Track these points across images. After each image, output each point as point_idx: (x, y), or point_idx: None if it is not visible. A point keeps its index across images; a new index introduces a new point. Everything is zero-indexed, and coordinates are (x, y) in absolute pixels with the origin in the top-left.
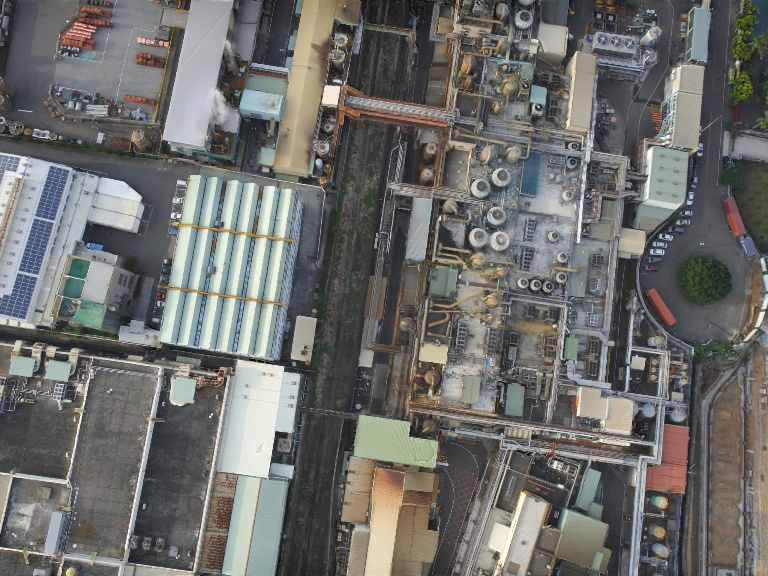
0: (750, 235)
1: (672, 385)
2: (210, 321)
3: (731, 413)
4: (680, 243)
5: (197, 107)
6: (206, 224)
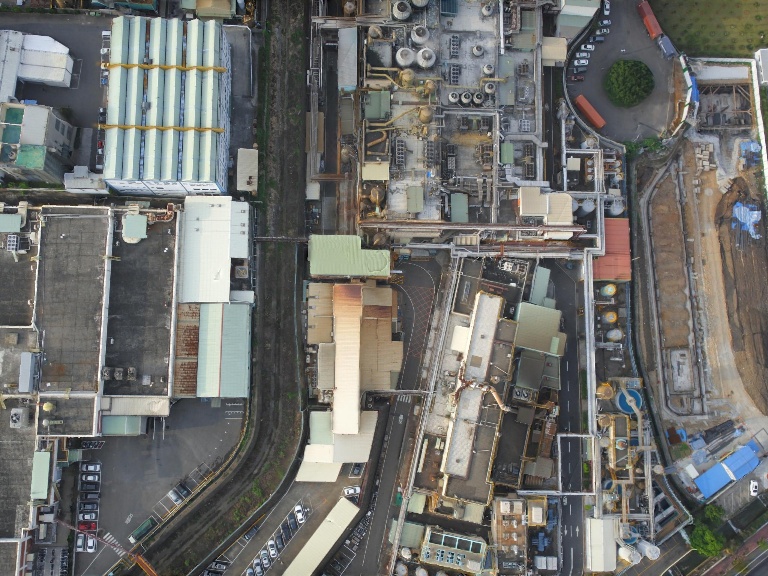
0: (667, 36)
1: (608, 182)
2: (151, 153)
3: (668, 207)
4: (602, 52)
5: None
6: (135, 62)
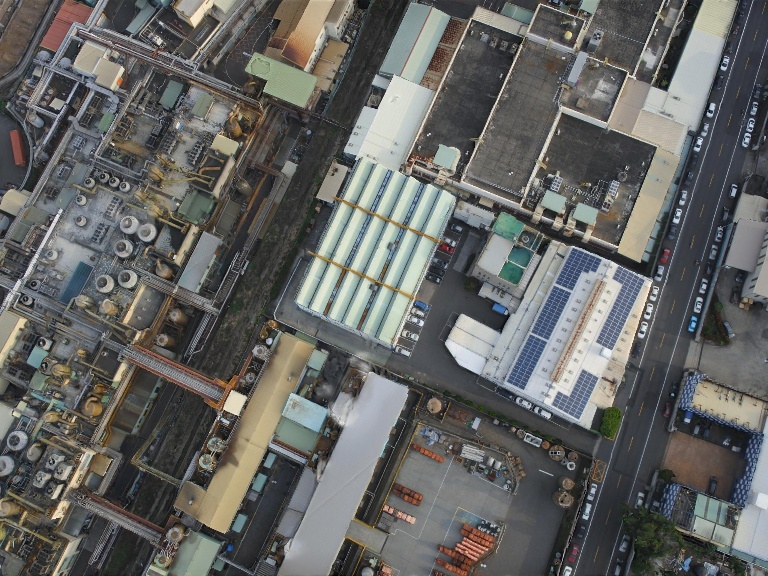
0: None
1: None
2: (404, 200)
3: (2, 57)
4: None
5: (366, 414)
6: (386, 290)
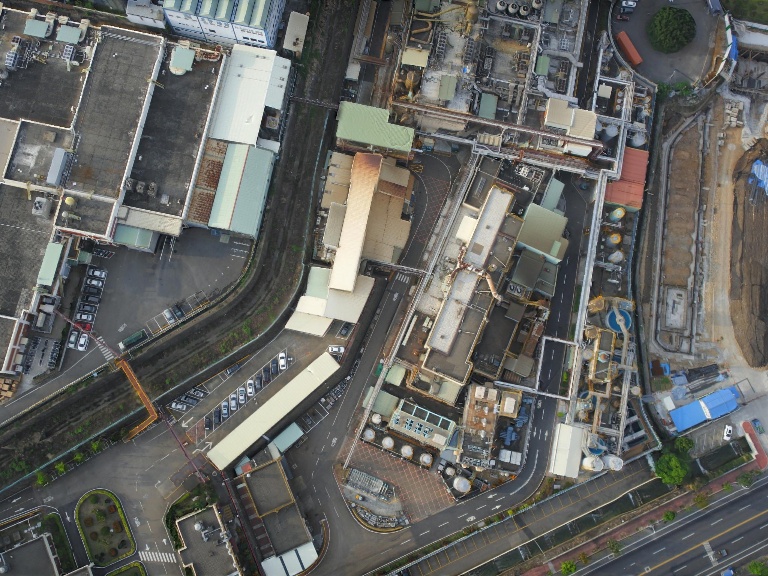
0: None
1: (635, 115)
2: None
3: (690, 154)
4: None
5: None
6: None
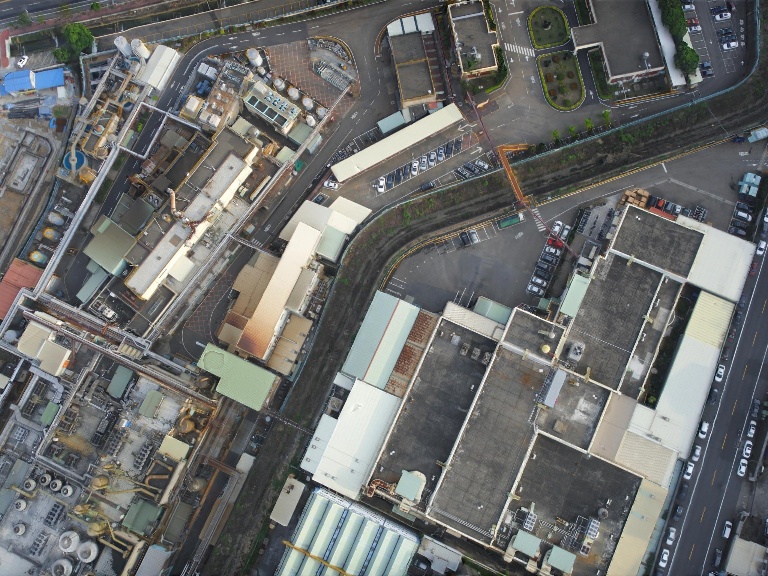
0: None
1: None
2: (361, 548)
3: None
4: None
5: None
6: None
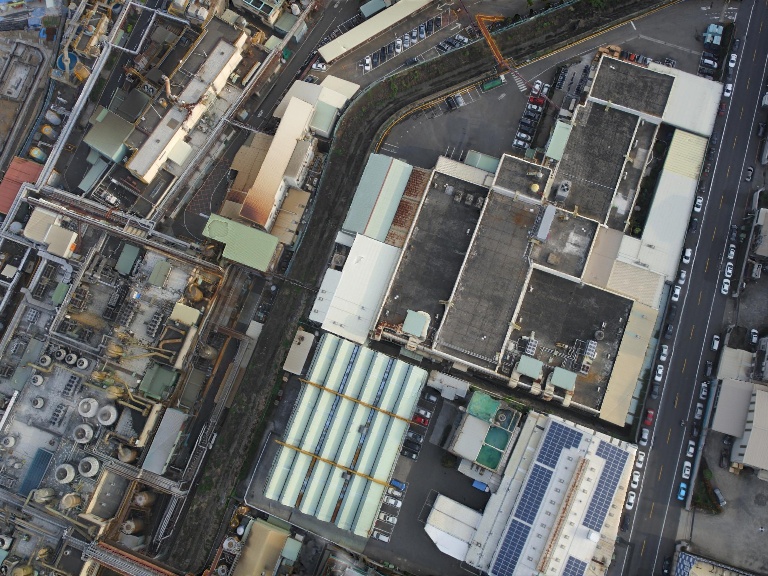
0: None
1: None
2: (373, 379)
3: None
4: None
5: None
6: (359, 479)
